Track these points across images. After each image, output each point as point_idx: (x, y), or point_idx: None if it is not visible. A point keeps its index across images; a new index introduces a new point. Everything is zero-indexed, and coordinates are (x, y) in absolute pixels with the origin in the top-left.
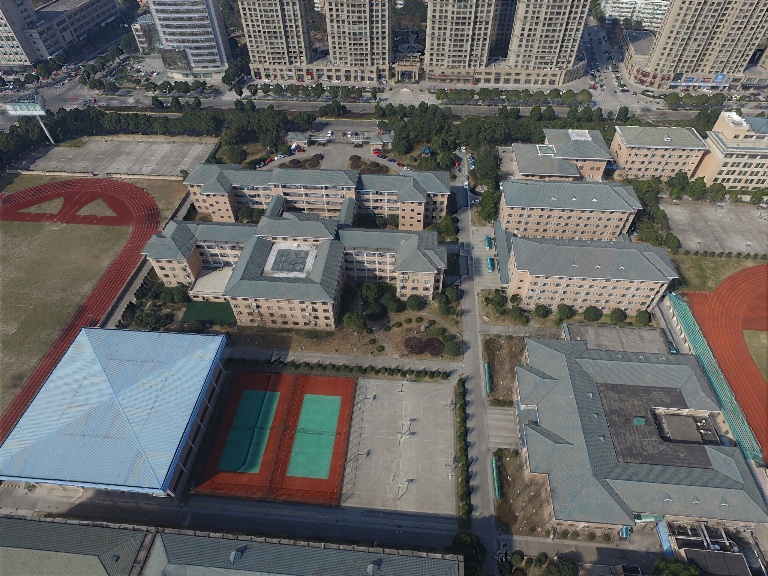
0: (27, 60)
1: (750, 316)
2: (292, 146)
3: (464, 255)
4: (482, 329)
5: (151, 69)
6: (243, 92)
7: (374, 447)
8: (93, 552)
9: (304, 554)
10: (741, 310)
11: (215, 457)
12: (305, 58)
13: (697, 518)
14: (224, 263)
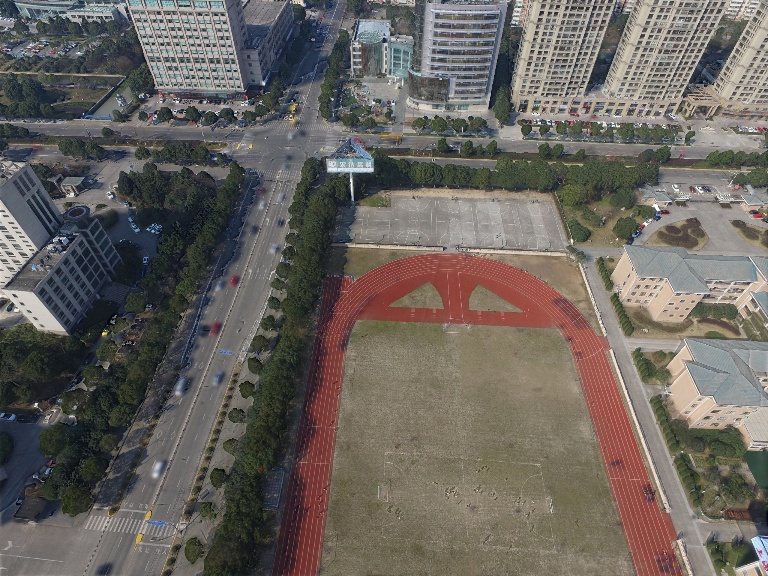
0: (241, 86)
1: None
2: (655, 207)
3: None
4: None
5: (381, 97)
6: (518, 129)
7: None
8: None
9: None
10: None
11: None
12: (584, 89)
13: None
14: None
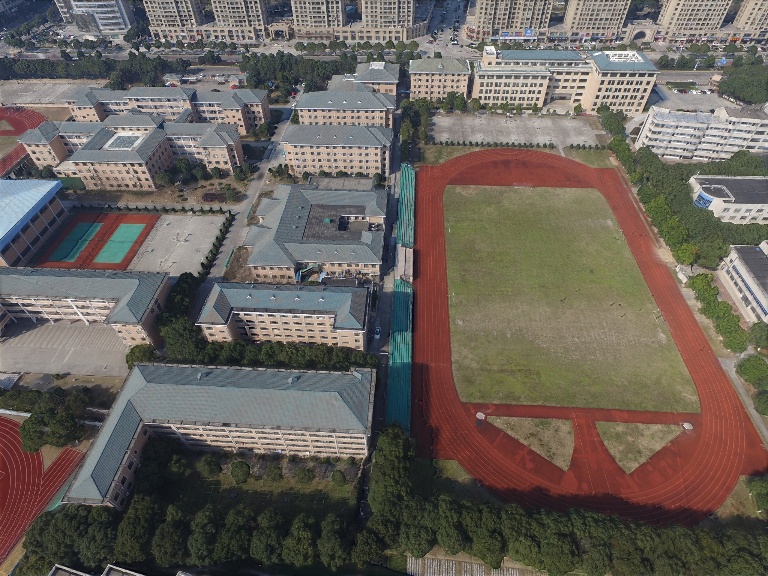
0: None
1: (457, 177)
2: (166, 83)
3: (271, 148)
4: (262, 188)
5: (70, 34)
6: (142, 49)
7: (157, 248)
8: None
9: (71, 272)
10: (453, 174)
11: (47, 255)
12: (195, 21)
13: (342, 267)
14: None
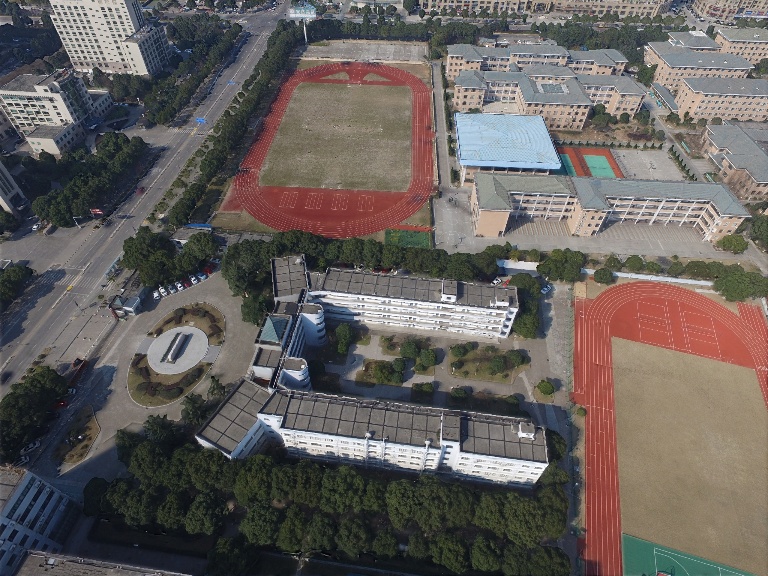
0: None
1: None
2: (486, 46)
3: None
4: (669, 131)
5: (334, 1)
6: None
7: (637, 173)
8: (550, 177)
9: None
10: None
11: None
12: None
13: None
14: (495, 99)
